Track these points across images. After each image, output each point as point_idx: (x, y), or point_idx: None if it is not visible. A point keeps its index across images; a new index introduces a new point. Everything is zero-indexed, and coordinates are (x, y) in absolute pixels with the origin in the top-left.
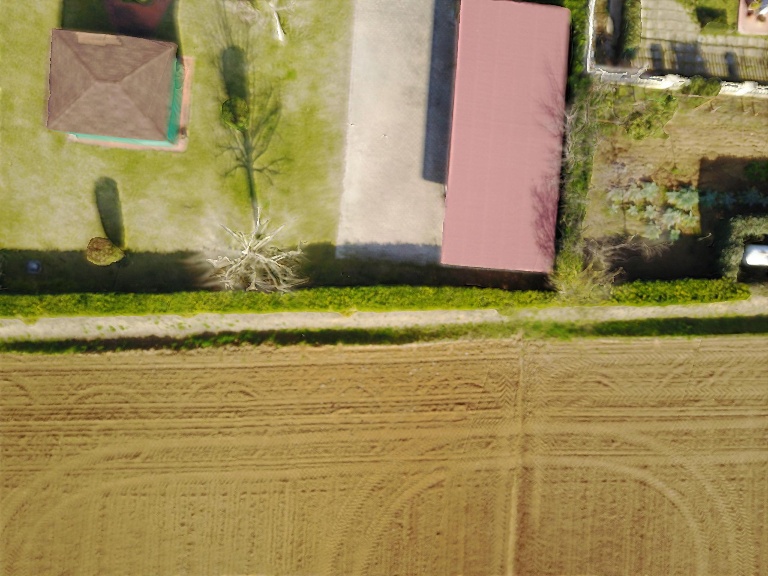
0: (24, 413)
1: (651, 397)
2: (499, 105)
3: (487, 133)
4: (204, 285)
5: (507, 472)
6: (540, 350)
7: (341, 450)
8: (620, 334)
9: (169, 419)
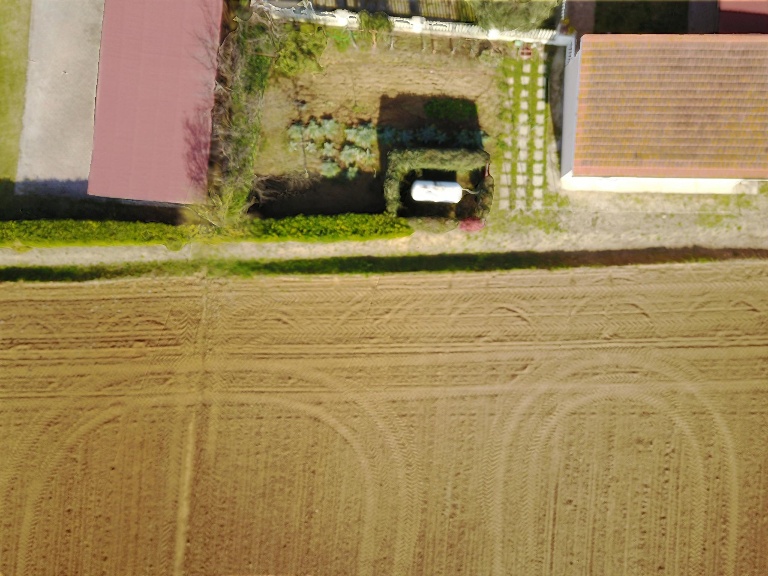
0: None
1: (329, 334)
2: (150, 37)
3: (136, 64)
4: None
5: (185, 408)
6: (223, 288)
7: (18, 385)
8: (300, 272)
9: None
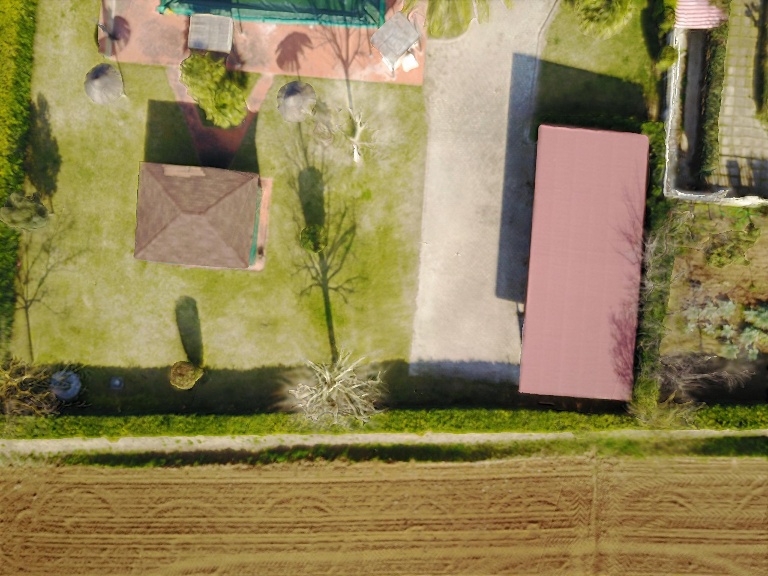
0: (106, 525)
1: (729, 519)
2: (576, 233)
3: (565, 262)
4: (280, 401)
5: None
6: (614, 468)
7: (414, 567)
8: (696, 454)
9: (245, 534)
